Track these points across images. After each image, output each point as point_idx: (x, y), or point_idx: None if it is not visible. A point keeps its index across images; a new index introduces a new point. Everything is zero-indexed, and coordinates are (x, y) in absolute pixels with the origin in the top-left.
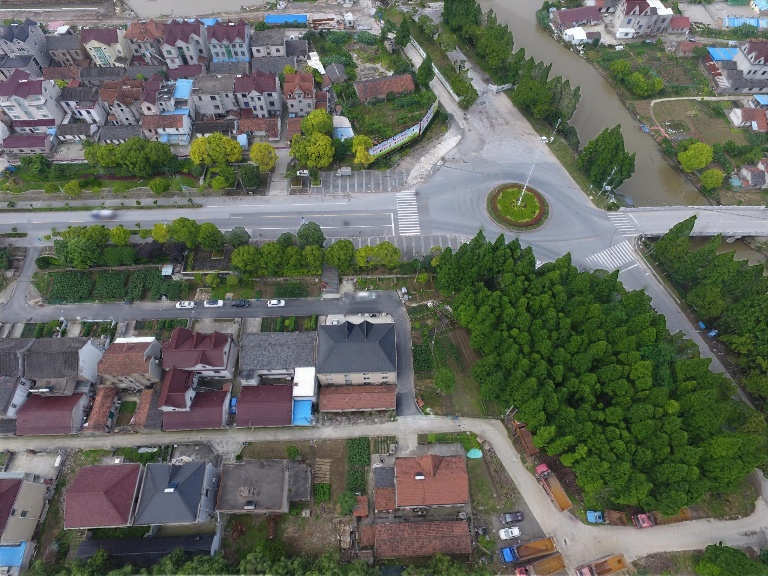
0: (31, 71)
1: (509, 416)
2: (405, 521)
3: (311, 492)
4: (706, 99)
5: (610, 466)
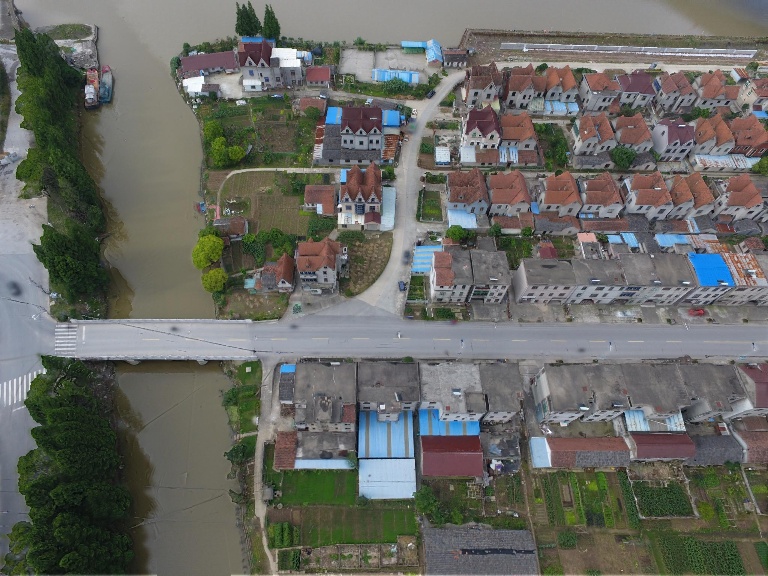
0: None
1: None
2: None
3: None
4: (296, 171)
5: None
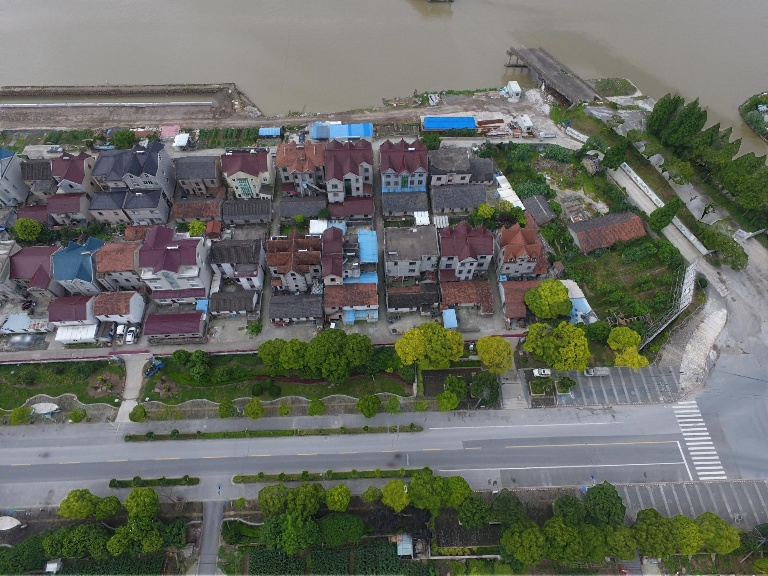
0: (160, 209)
1: None
2: None
3: None
4: None
5: None
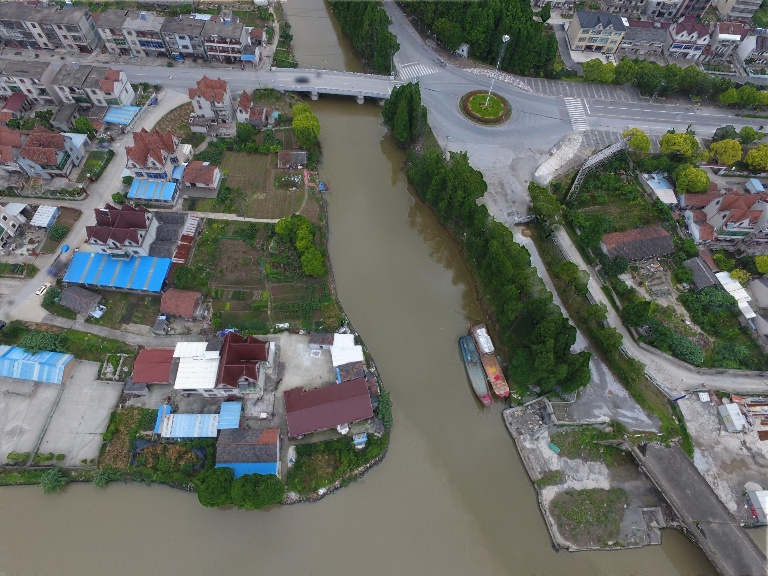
0: None
1: None
2: None
3: (599, 7)
4: (224, 215)
5: None
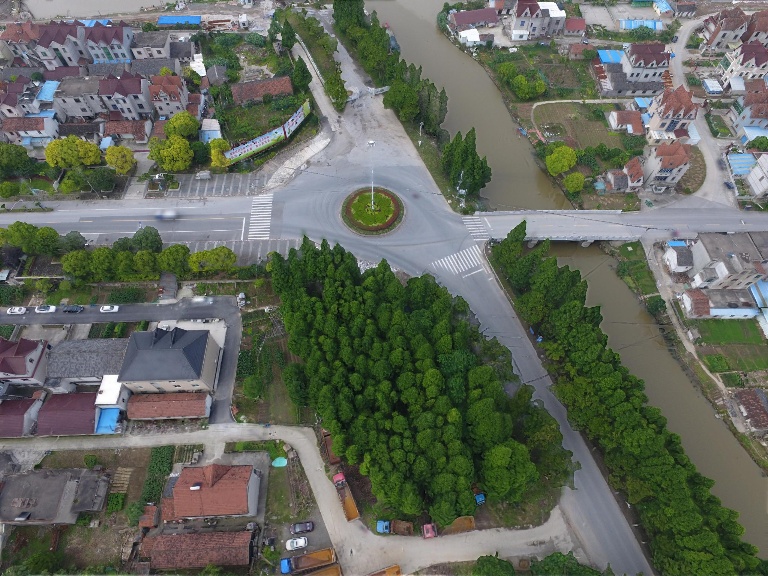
0: None
1: (319, 424)
2: (194, 532)
3: (104, 502)
4: (589, 102)
5: (385, 476)
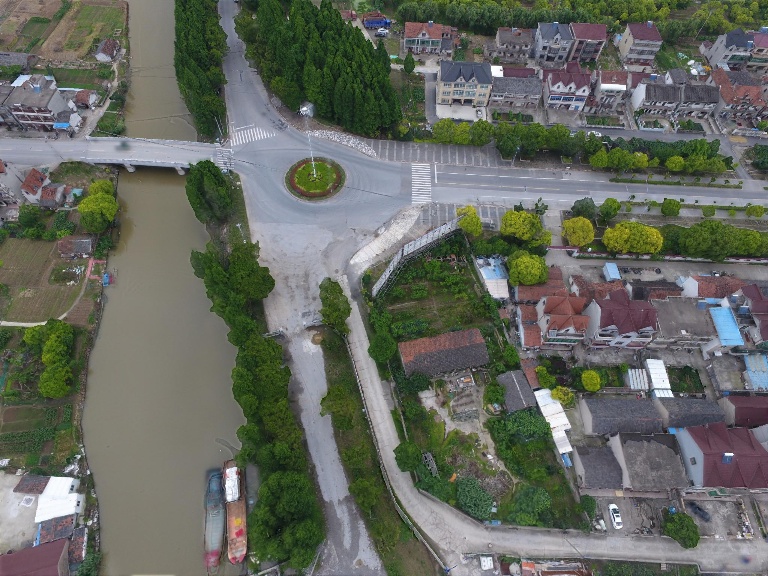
0: None
1: None
2: None
3: None
4: None
5: None
